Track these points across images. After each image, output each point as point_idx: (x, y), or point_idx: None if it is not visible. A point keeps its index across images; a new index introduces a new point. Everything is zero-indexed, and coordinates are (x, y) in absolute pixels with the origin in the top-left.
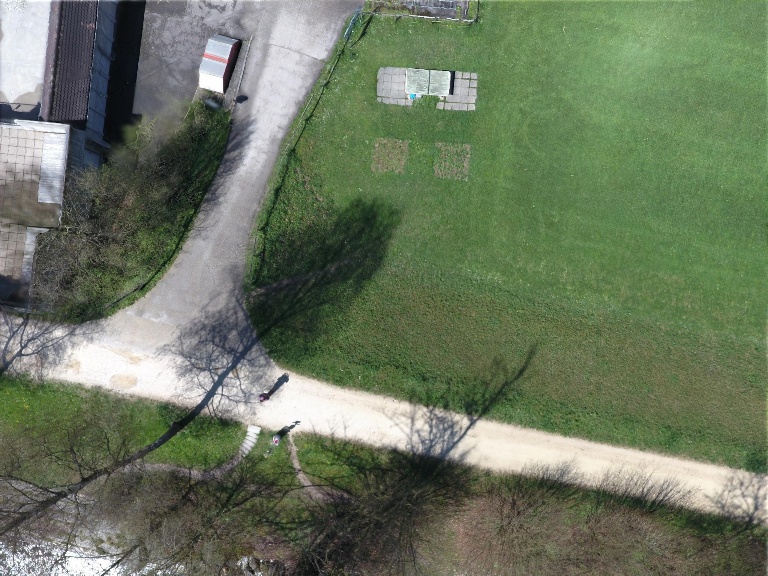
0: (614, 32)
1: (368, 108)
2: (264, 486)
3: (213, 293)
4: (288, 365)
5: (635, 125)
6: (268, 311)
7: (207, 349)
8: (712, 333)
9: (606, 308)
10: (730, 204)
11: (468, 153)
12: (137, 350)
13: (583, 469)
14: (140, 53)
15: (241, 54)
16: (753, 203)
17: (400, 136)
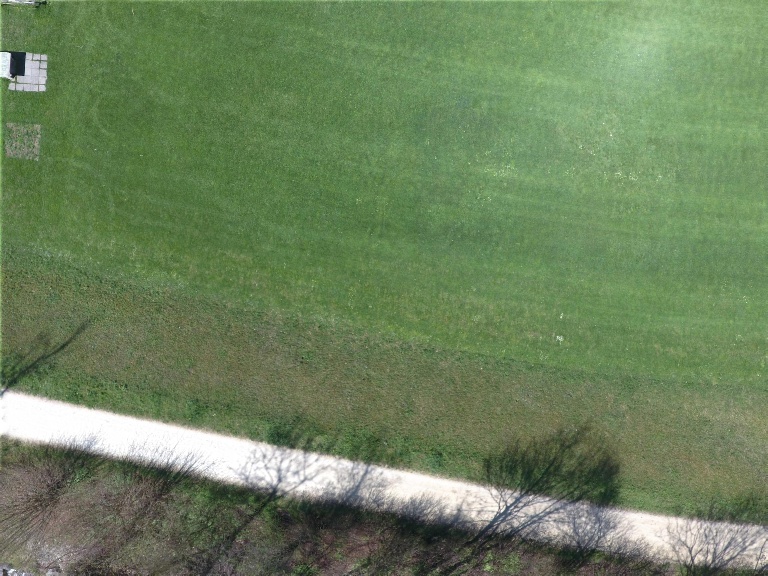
0: (181, 14)
1: None
2: None
3: None
4: None
5: (203, 106)
6: None
7: None
8: (278, 311)
9: (173, 286)
10: (296, 184)
11: (38, 133)
12: None
13: (109, 440)
14: None
15: None
16: (318, 183)
17: None
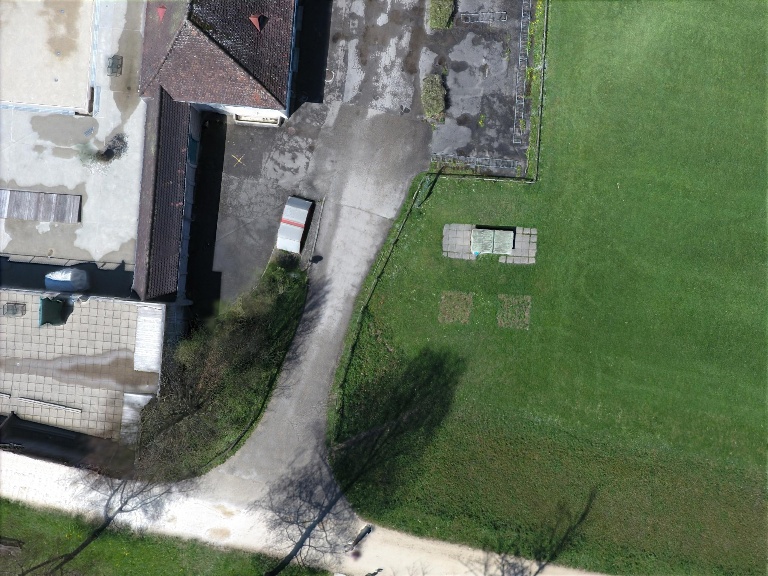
0: (666, 188)
1: (435, 263)
2: None
3: (298, 450)
4: (370, 518)
5: (685, 275)
6: (349, 466)
7: (295, 504)
8: (757, 467)
9: (658, 446)
10: None
11: (529, 304)
12: (230, 506)
13: None
14: (218, 214)
15: (315, 215)
16: None
17: (465, 289)
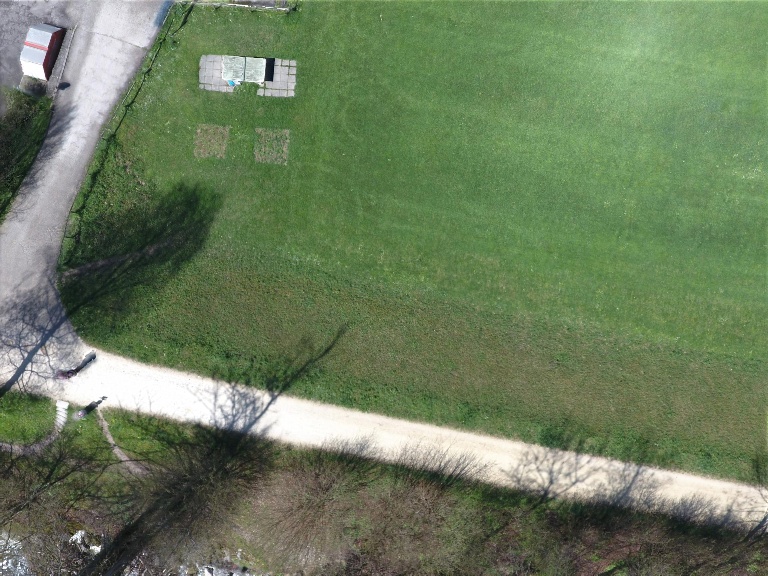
0: (430, 20)
1: (190, 95)
2: (83, 461)
3: (26, 273)
4: (95, 342)
5: (451, 111)
6: (79, 290)
7: (17, 327)
8: (526, 314)
9: (422, 289)
10: (543, 188)
11: (287, 138)
12: None
13: (382, 444)
14: None
15: (65, 42)
16: (566, 187)
17: (221, 122)
